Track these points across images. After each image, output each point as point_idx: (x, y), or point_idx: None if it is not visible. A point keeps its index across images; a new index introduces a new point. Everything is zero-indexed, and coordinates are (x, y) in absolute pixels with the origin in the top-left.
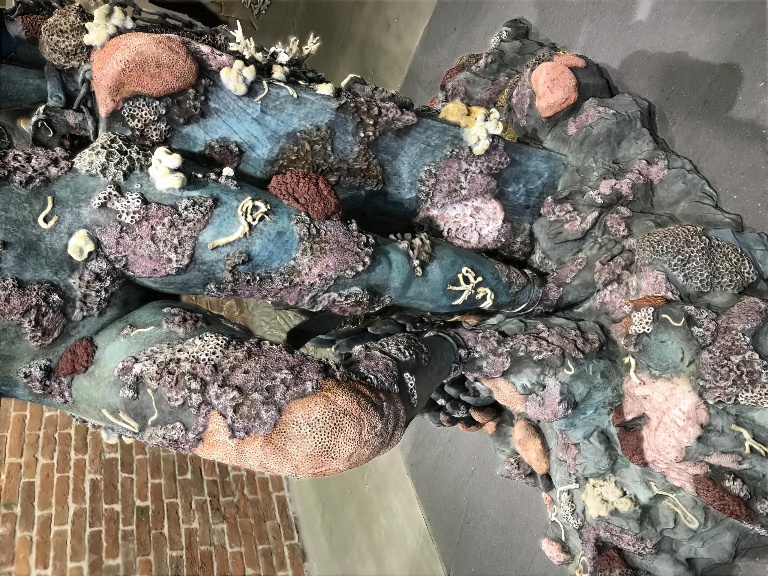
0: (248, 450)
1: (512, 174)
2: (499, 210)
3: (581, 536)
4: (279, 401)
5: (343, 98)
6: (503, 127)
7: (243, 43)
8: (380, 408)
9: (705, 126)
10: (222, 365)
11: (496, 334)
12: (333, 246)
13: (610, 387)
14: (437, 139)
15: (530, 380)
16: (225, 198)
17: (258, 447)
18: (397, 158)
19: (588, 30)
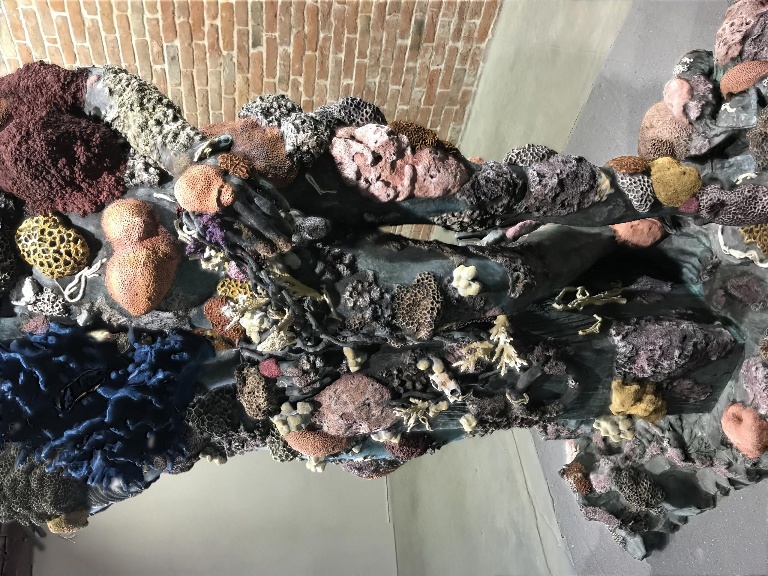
0: None
1: None
2: None
3: None
4: None
5: None
6: None
7: None
8: None
9: None
10: None
11: None
12: None
13: None
14: None
15: None
16: None
17: None
18: None
19: None
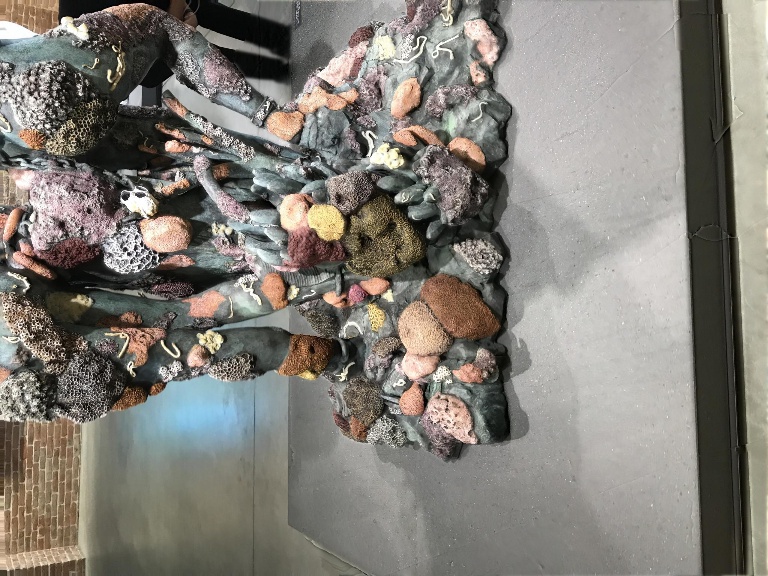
0: None
1: None
2: None
3: (413, 30)
4: None
5: None
6: None
7: None
8: None
9: None
10: None
11: None
12: None
13: None
14: None
15: None
16: None
17: None
18: None
19: None
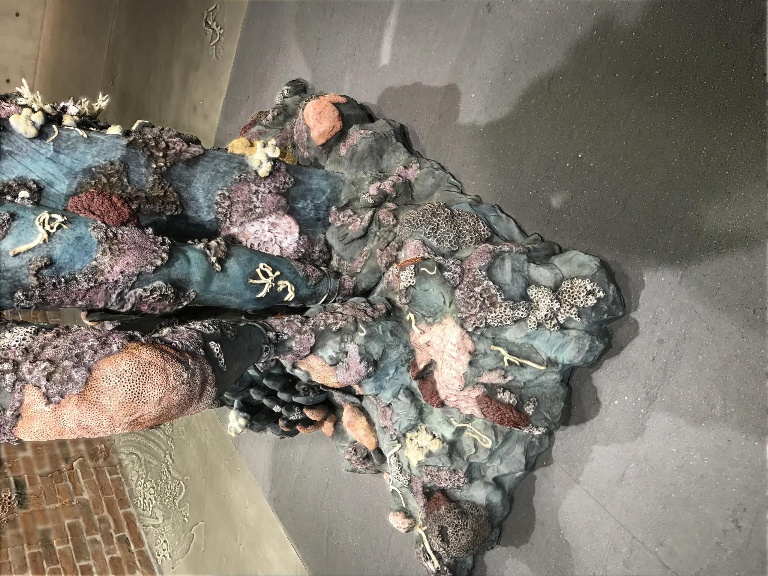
0: (65, 412)
1: (299, 192)
2: (294, 224)
3: (412, 490)
4: (88, 363)
5: (131, 136)
6: (283, 153)
7: (31, 98)
8: (185, 363)
9: (443, 135)
10: (32, 346)
11: (299, 317)
12: (131, 246)
13: (402, 344)
14: (225, 166)
15: (334, 350)
16: (22, 213)
17: (74, 407)
18: (191, 185)
19: (350, 79)
